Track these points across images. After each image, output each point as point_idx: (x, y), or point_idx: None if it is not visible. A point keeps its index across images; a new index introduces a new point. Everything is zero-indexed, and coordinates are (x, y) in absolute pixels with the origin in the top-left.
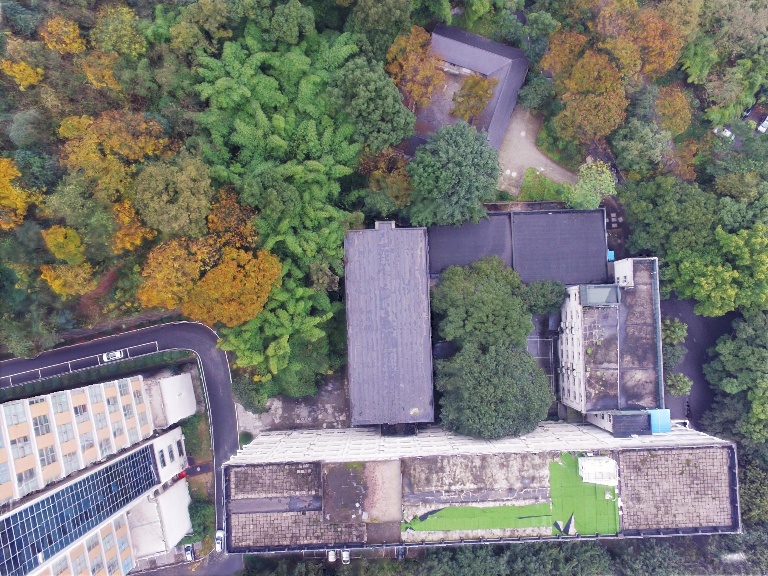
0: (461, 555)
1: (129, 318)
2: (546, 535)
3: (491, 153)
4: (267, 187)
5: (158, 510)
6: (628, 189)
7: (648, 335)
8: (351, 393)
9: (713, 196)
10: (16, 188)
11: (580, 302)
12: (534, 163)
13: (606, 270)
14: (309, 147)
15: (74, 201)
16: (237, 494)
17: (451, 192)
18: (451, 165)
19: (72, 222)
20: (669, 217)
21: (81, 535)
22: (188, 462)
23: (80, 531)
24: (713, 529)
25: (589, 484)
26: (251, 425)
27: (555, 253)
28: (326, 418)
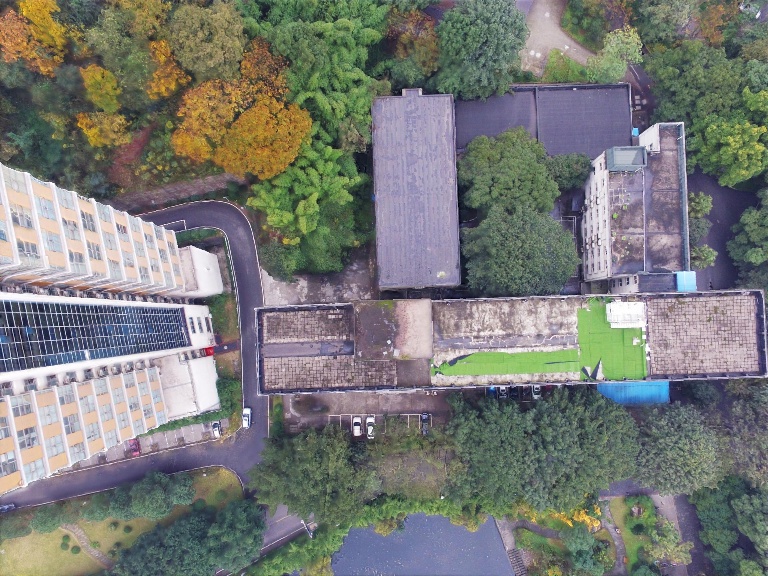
0: (488, 412)
1: (159, 190)
2: (574, 380)
3: (519, 13)
4: (298, 40)
5: (189, 371)
6: (654, 58)
7: (674, 200)
8: (378, 257)
9: (740, 60)
10: (56, 20)
11: (606, 166)
12: (558, 44)
13: (631, 144)
14: (338, 10)
15: (112, 36)
16: (269, 338)
17: (478, 53)
18: (479, 21)
19: (109, 62)
20: (696, 81)
21: (122, 355)
22: (215, 341)
23: (121, 351)
24: (740, 375)
25: (617, 331)
26: (277, 304)
27: (580, 128)
28: (351, 297)
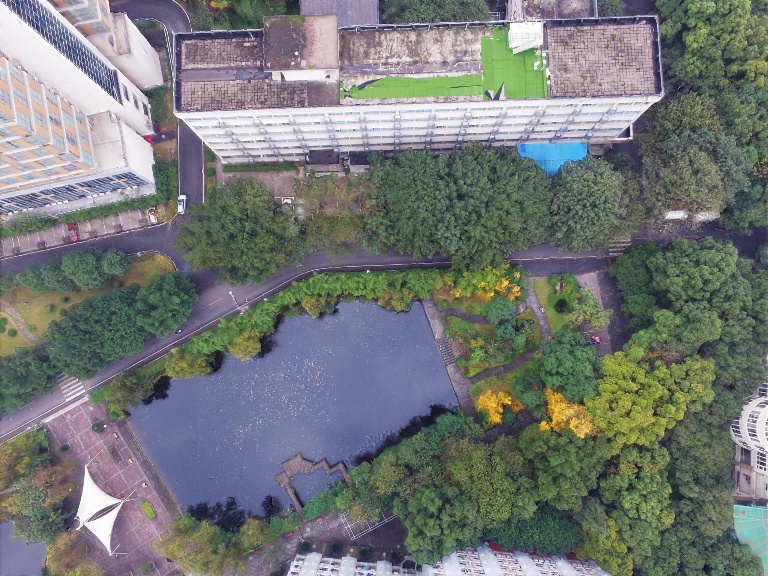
0: (402, 156)
1: None
2: None
3: None
4: None
5: (119, 128)
6: None
7: None
8: None
9: None
10: None
11: None
12: None
13: None
14: None
15: None
16: (187, 64)
17: None
18: None
19: None
20: None
21: None
22: (153, 129)
23: None
24: None
25: (519, 57)
26: None
27: None
28: None
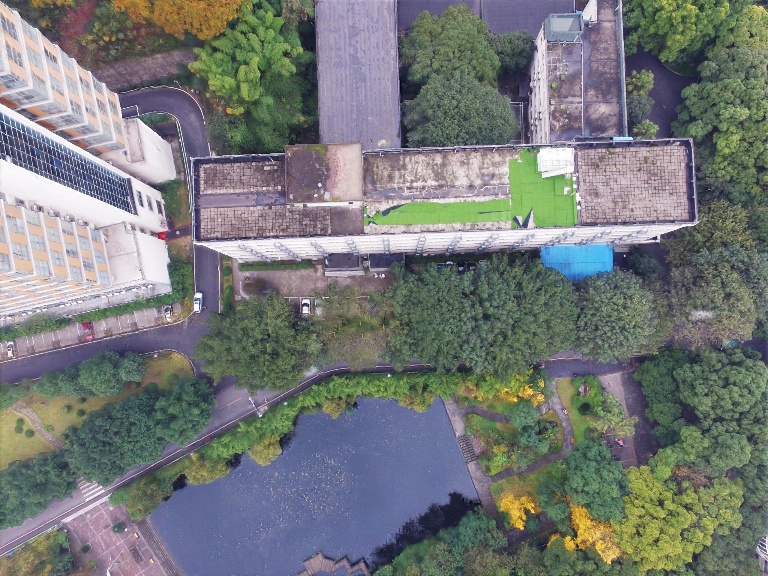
0: (426, 273)
1: (109, 70)
2: None
3: None
4: None
5: (135, 240)
6: None
7: (612, 70)
8: (321, 126)
9: None
10: None
11: (544, 36)
12: None
13: None
14: None
15: None
16: (206, 189)
17: None
18: None
19: None
20: None
21: None
22: (168, 226)
23: (51, 179)
24: None
25: (548, 181)
26: None
27: (523, 9)
28: None
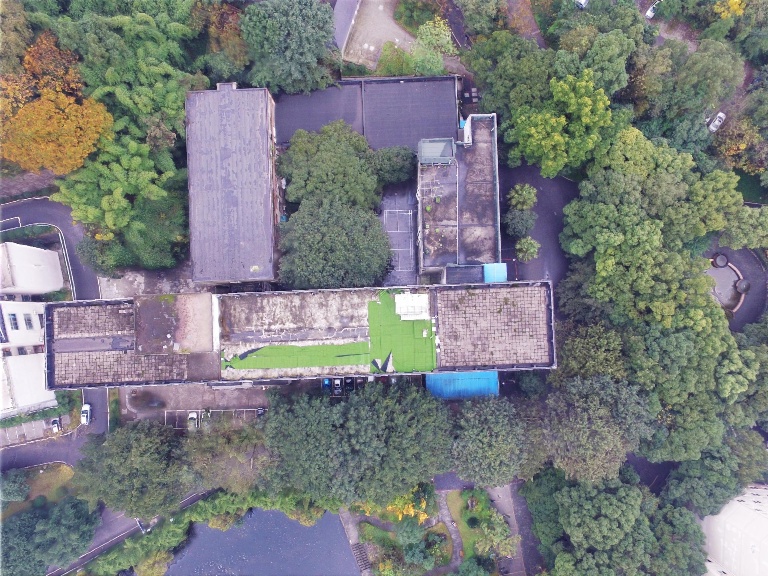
0: (296, 405)
1: None
2: (364, 372)
3: (322, 6)
4: None
5: (5, 368)
6: None
7: (488, 192)
8: (192, 251)
9: (550, 50)
10: None
11: None
12: (392, 37)
13: (457, 137)
14: (144, 4)
15: None
16: (60, 334)
17: (284, 46)
18: (277, 14)
19: None
20: (506, 72)
21: None
22: None
23: None
24: (530, 366)
25: (407, 323)
26: None
27: (406, 121)
28: None
